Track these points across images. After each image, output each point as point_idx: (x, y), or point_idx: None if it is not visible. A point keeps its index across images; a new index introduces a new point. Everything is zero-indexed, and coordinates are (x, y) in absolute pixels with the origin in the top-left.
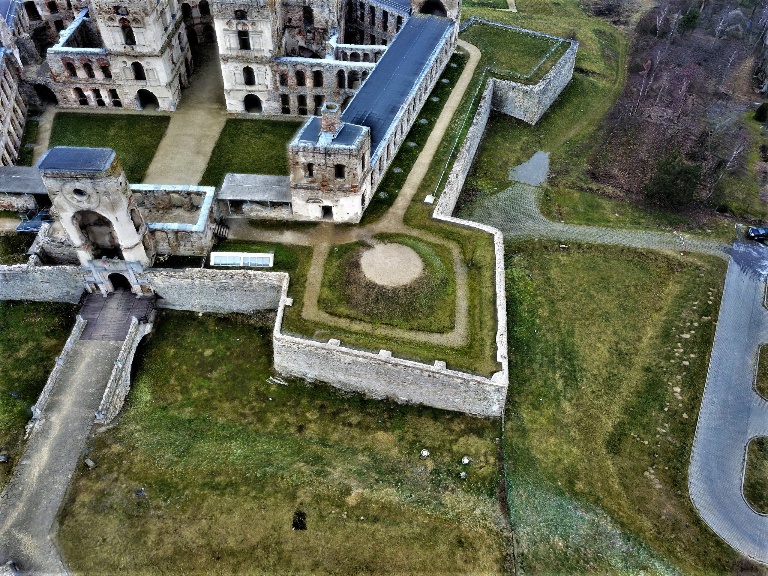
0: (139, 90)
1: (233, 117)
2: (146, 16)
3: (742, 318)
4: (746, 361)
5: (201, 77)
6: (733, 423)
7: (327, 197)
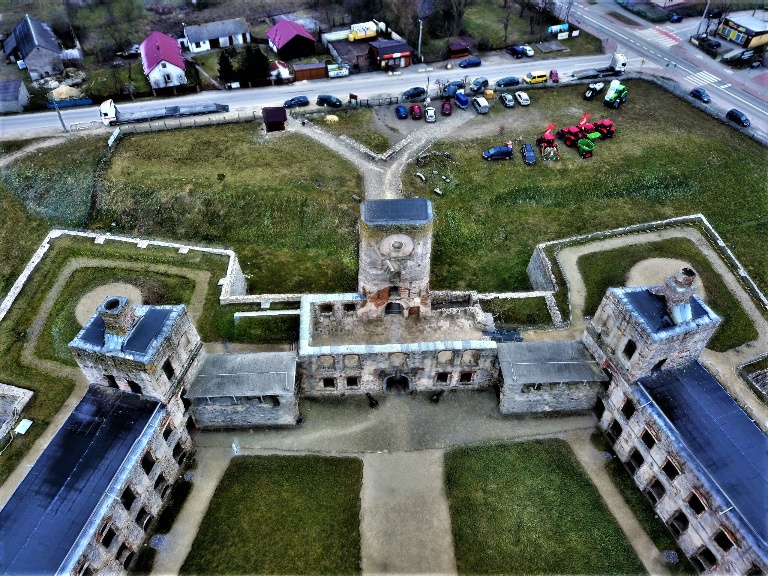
0: None
1: None
2: None
3: None
4: None
5: None
6: None
7: None
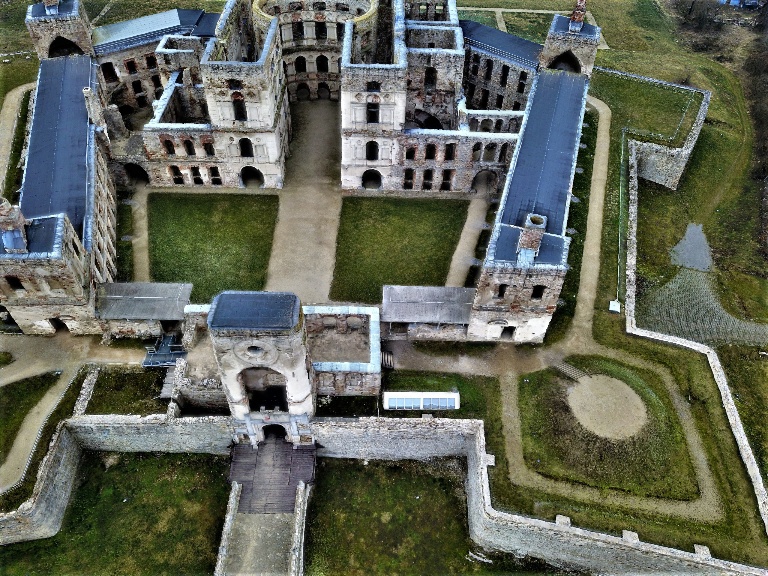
0: (244, 167)
1: (349, 194)
2: (263, 90)
3: None
4: None
5: (302, 144)
6: None
7: (514, 318)
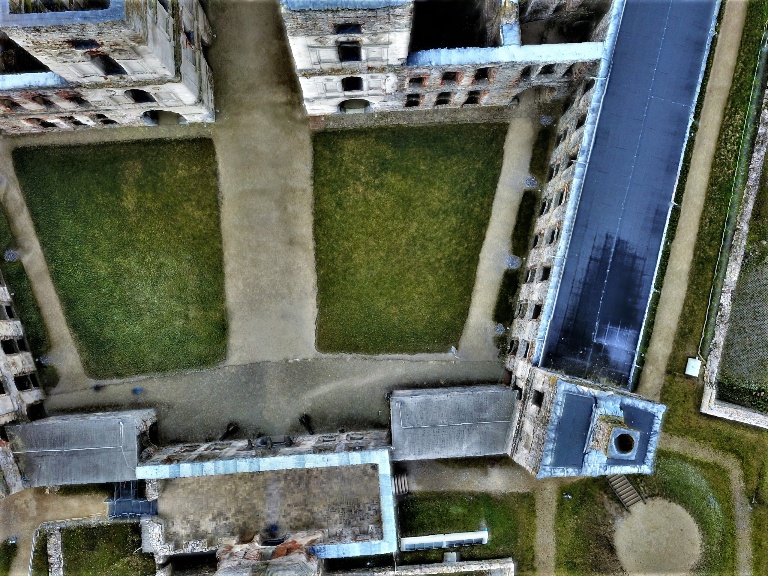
0: (146, 111)
1: (321, 127)
2: (139, 44)
3: None
4: None
5: (228, 2)
6: None
7: None
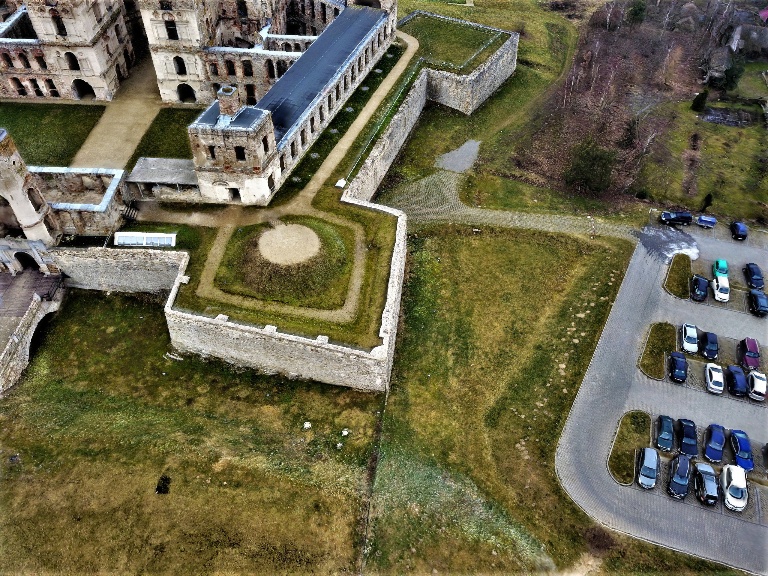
0: (74, 80)
1: (167, 106)
2: (74, 7)
3: (639, 299)
4: (635, 339)
5: (142, 68)
6: (611, 398)
7: (232, 179)
